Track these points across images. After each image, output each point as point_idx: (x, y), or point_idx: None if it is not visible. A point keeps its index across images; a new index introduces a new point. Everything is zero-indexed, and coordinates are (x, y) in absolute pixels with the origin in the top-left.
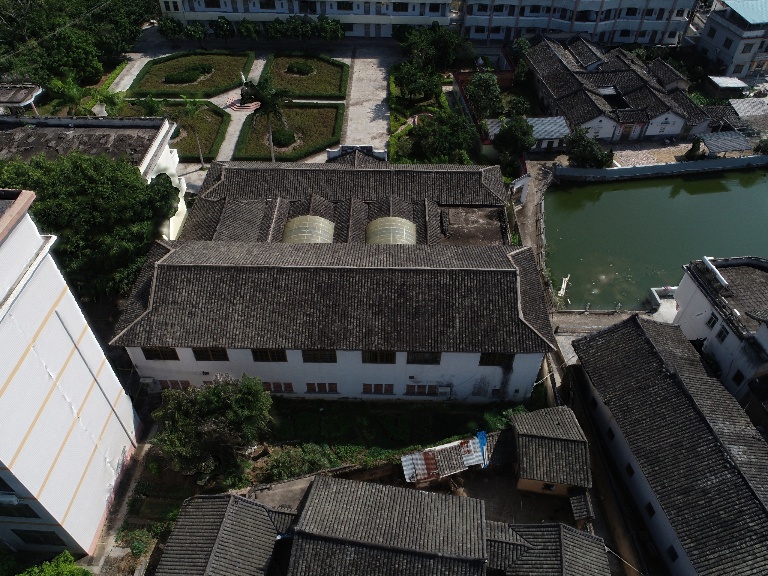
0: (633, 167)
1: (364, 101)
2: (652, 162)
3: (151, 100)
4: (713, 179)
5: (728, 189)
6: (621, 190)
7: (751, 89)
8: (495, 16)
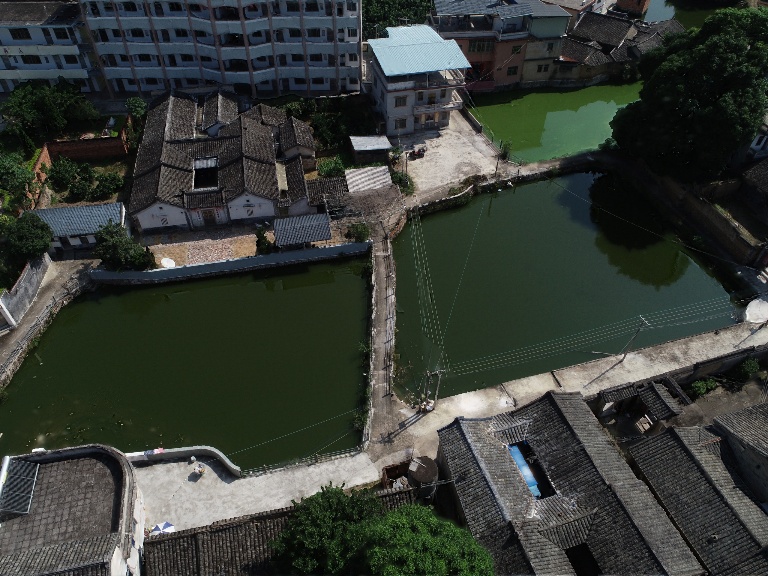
0: (183, 267)
1: None
2: (225, 255)
3: None
4: (290, 275)
5: (333, 280)
6: (186, 291)
7: (395, 151)
8: (137, 67)
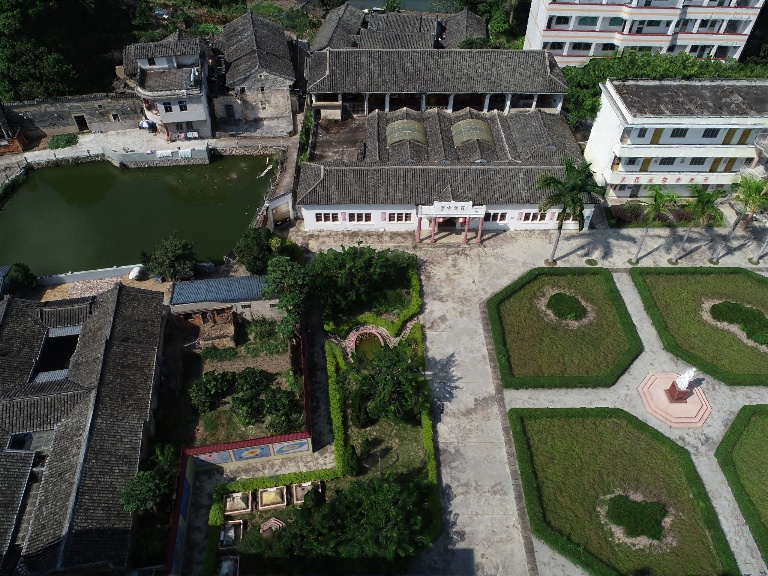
0: None
1: (474, 409)
2: (77, 294)
3: (710, 197)
4: None
5: None
6: None
7: None
8: None
